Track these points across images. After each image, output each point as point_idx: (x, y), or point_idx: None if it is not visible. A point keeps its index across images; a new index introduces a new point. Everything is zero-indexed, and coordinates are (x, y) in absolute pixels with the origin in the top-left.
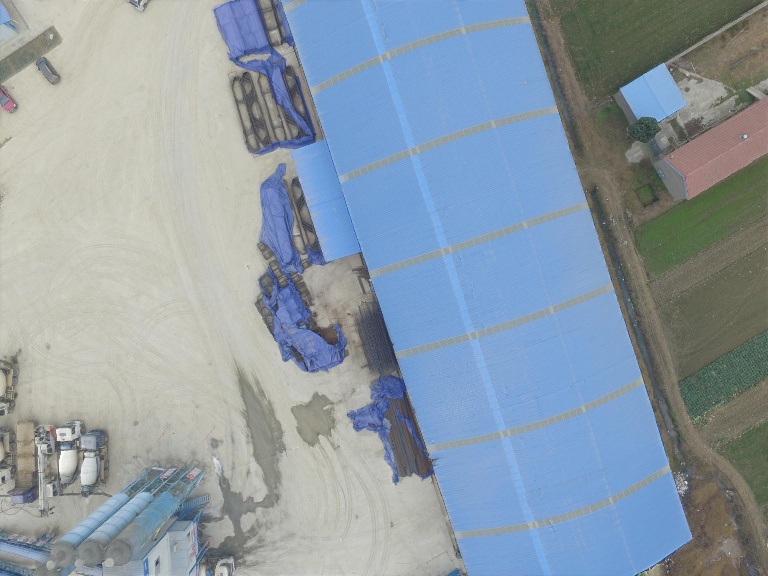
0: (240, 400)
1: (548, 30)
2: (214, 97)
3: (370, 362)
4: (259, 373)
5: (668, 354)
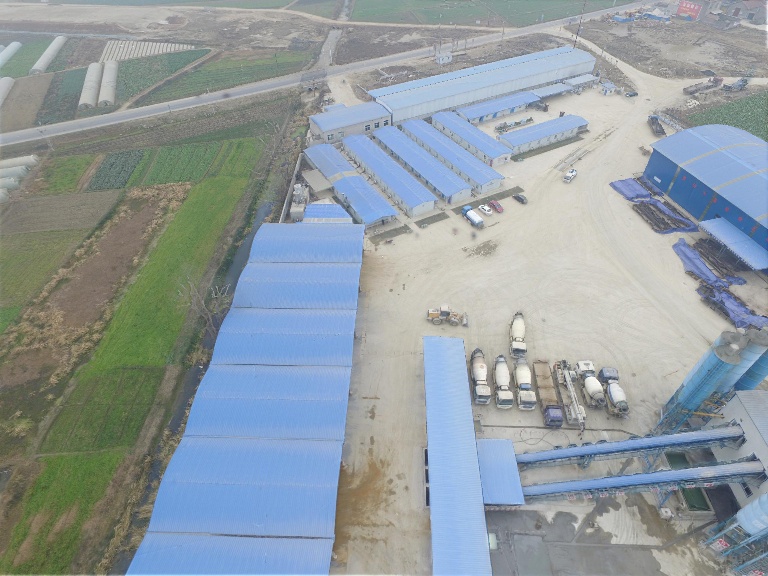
0: None
1: None
2: (622, 212)
3: None
4: None
5: None
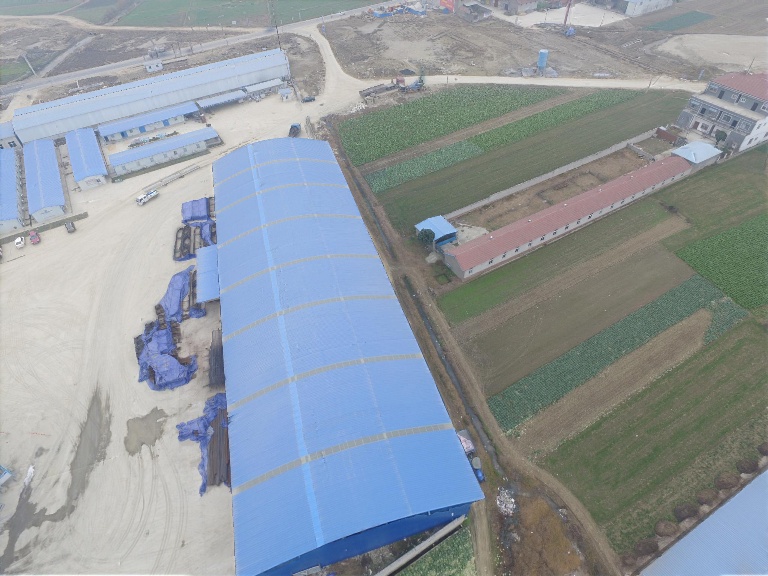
0: (85, 413)
1: (375, 210)
2: (164, 237)
3: (212, 382)
4: (113, 391)
5: (473, 378)
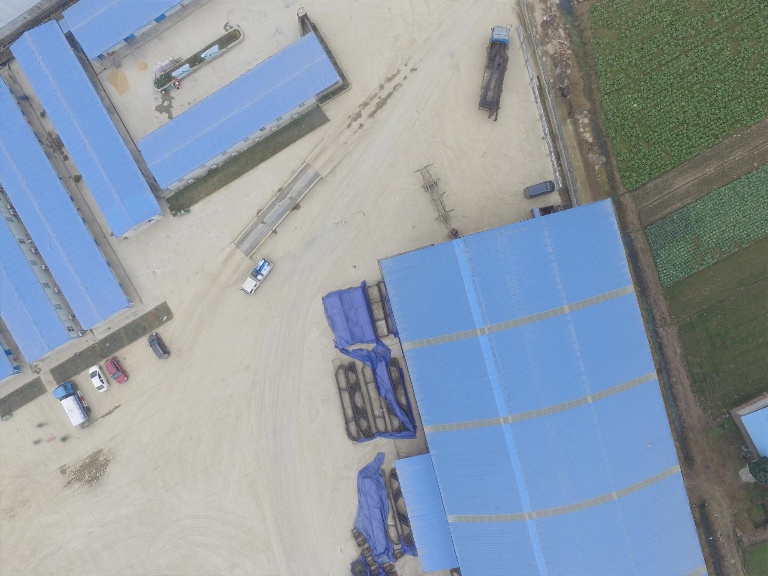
0: None
1: (664, 339)
2: (317, 382)
3: None
4: None
5: None
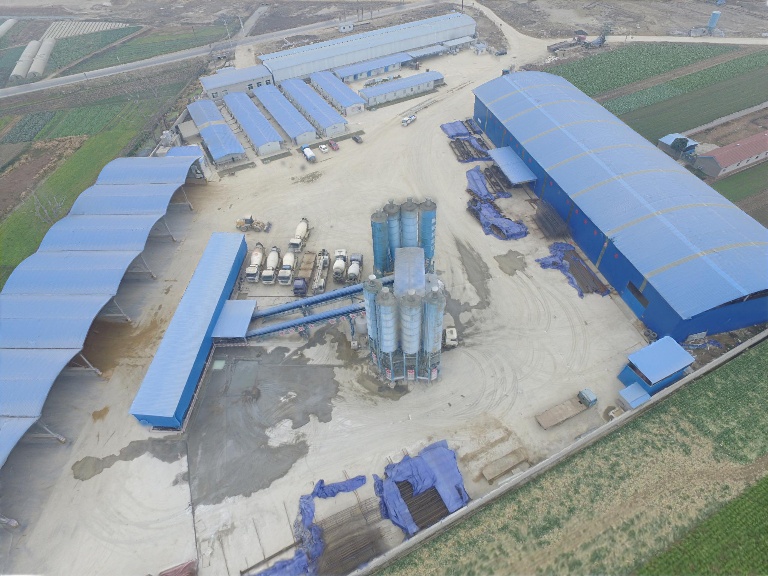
0: (457, 252)
1: None
2: (440, 147)
3: (546, 236)
4: (470, 240)
5: None
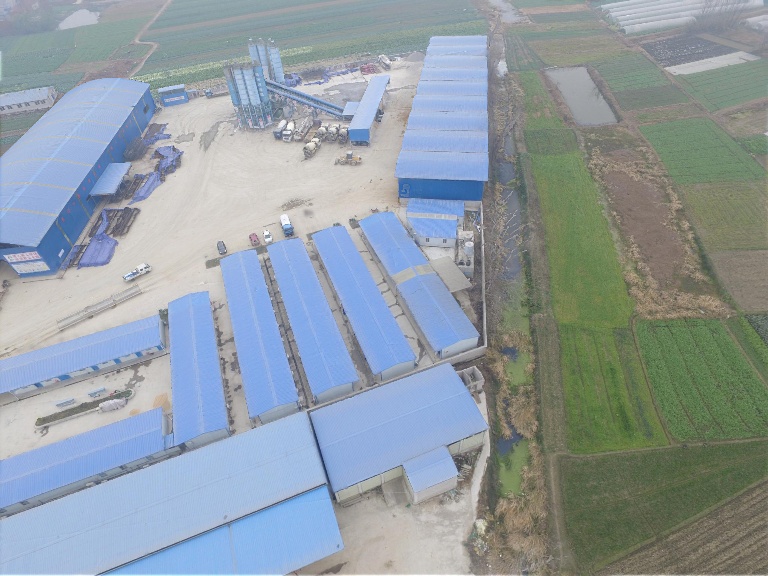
0: None
1: None
2: None
3: None
4: None
5: None
